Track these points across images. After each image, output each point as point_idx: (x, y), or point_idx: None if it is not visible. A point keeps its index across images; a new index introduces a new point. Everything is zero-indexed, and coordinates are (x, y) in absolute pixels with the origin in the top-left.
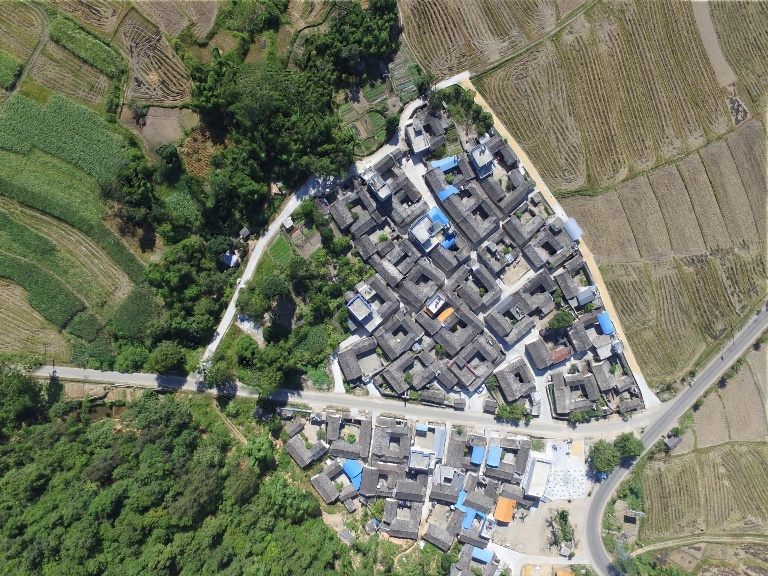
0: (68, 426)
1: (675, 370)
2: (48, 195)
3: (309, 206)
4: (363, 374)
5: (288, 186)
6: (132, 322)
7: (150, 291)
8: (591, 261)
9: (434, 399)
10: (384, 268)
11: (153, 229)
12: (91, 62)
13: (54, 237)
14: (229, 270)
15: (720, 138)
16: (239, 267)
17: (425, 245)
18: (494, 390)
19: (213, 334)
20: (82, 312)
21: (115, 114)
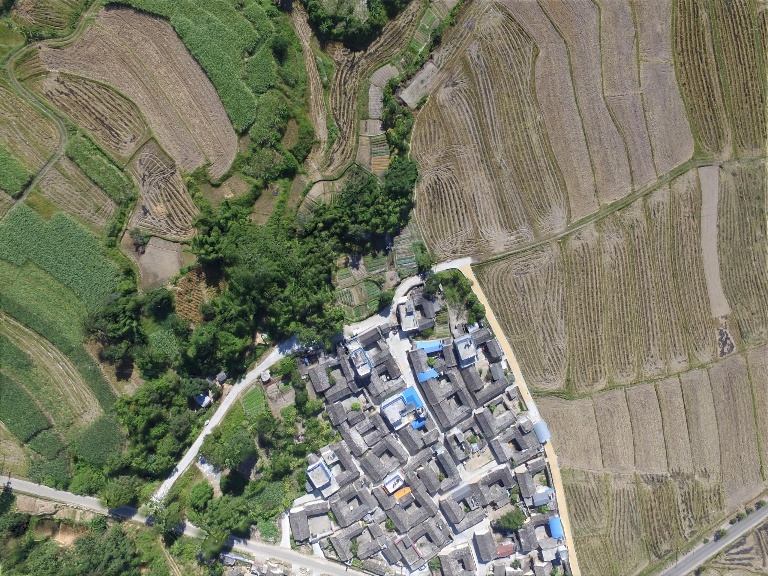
0: (11, 546)
1: None
2: (34, 310)
3: (288, 367)
4: (311, 534)
5: (273, 338)
6: (94, 449)
7: (117, 421)
8: (554, 462)
9: (375, 571)
10: (351, 438)
11: (132, 359)
12: (101, 185)
13: (33, 351)
14: (199, 410)
15: (703, 366)
16: (210, 407)
17: (395, 423)
18: (436, 569)
19: (172, 470)
20: (47, 430)
21: (116, 237)
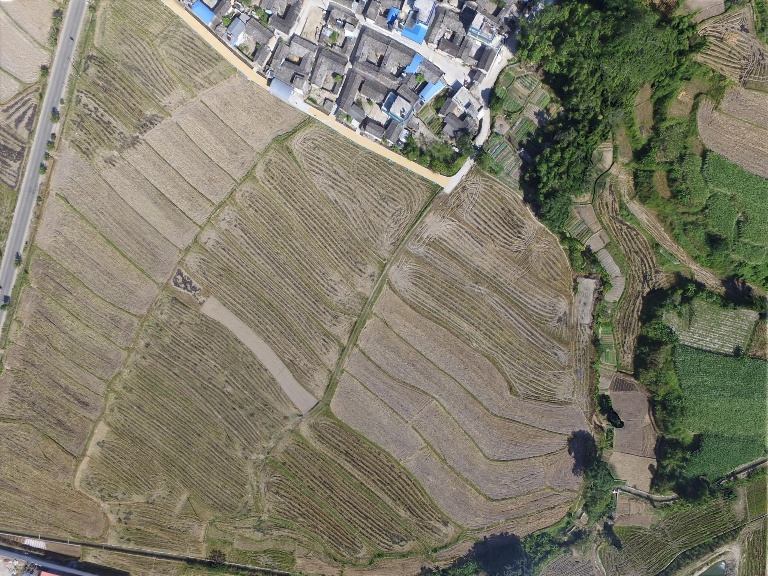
0: None
1: (111, 5)
2: None
3: None
4: None
5: None
6: None
7: None
8: (247, 72)
9: None
10: None
11: None
12: None
13: None
14: None
15: (187, 250)
16: None
17: None
18: None
19: None
20: None
21: None
